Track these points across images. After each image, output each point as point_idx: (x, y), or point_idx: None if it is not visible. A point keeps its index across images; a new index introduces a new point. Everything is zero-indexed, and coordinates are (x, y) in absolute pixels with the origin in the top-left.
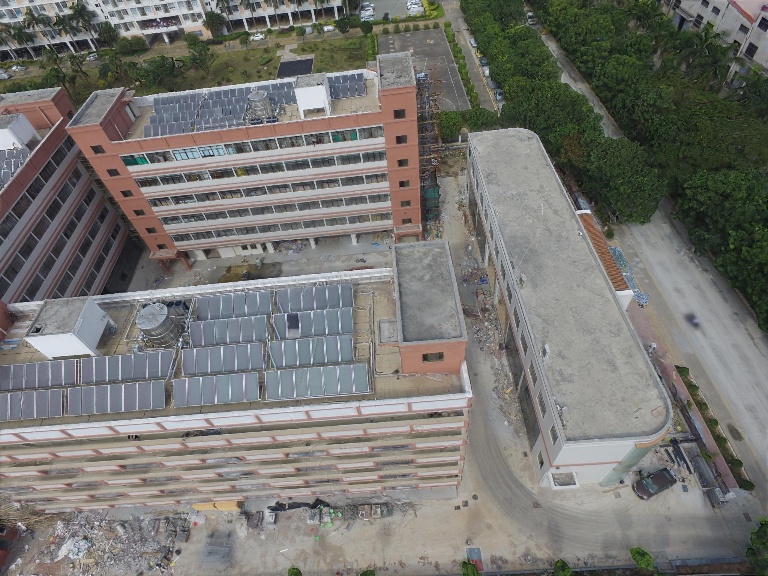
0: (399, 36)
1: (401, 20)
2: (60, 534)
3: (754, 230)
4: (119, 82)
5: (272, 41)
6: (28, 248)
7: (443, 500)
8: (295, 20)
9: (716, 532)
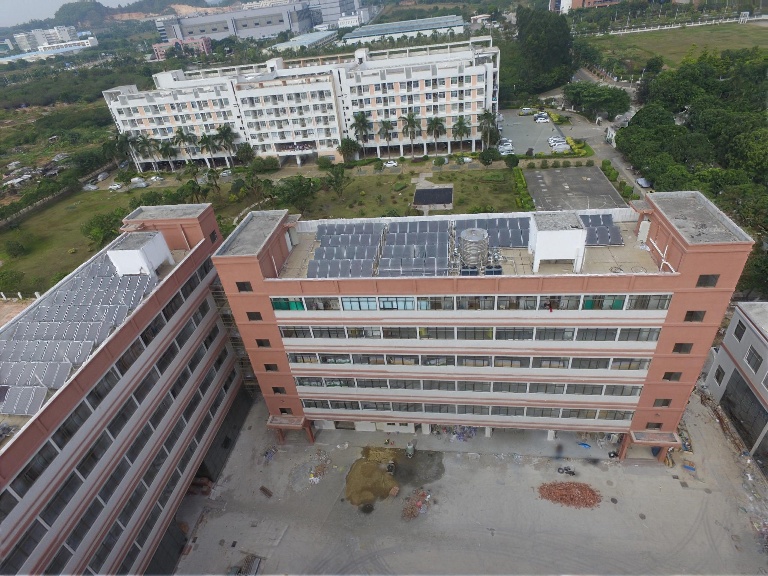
0: (547, 171)
1: (546, 156)
2: None
3: None
4: (249, 197)
5: (405, 169)
6: (122, 418)
7: None
8: (428, 151)
9: None
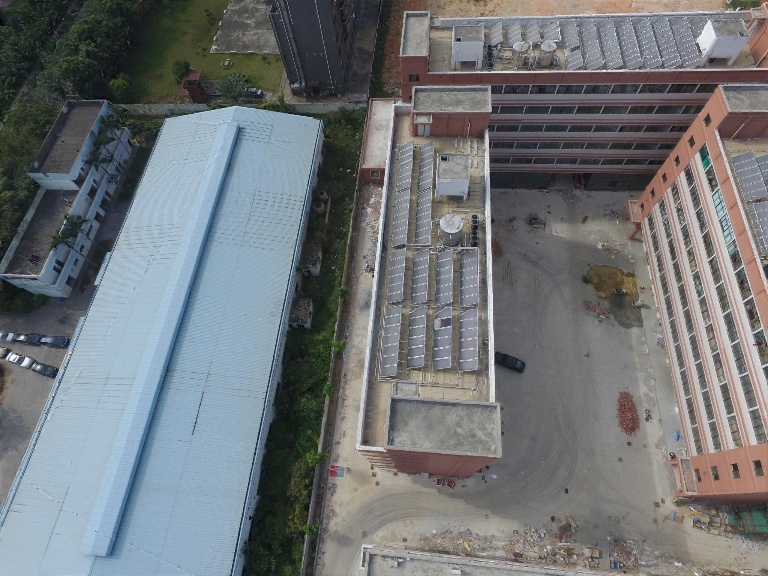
0: None
1: None
2: None
3: None
4: None
5: None
6: (588, 110)
7: None
8: None
9: None
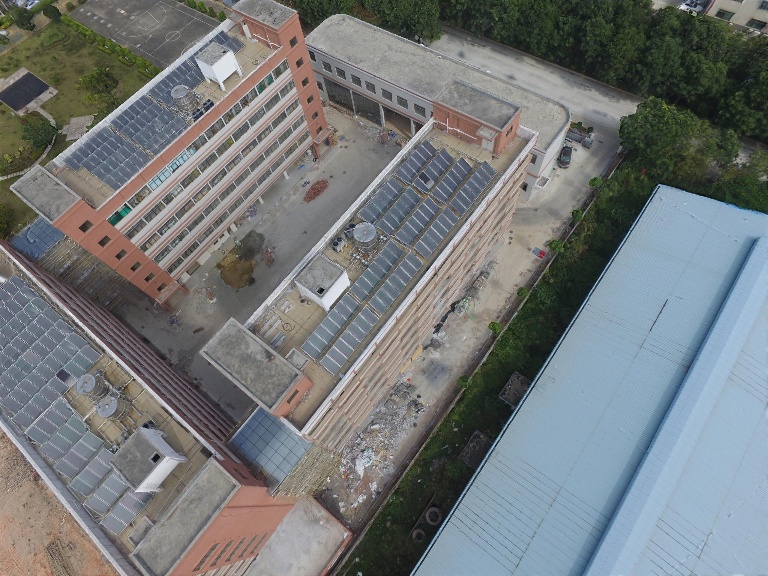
0: (89, 5)
1: None
2: (345, 469)
3: (502, 2)
4: None
5: None
6: None
7: (501, 247)
8: None
9: (598, 157)
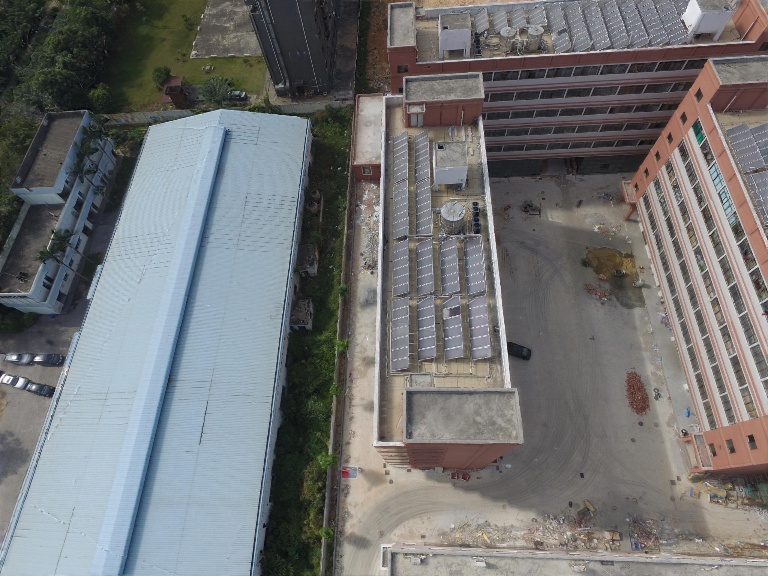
0: None
1: None
2: None
3: None
4: None
5: None
6: (578, 93)
7: None
8: None
9: None
